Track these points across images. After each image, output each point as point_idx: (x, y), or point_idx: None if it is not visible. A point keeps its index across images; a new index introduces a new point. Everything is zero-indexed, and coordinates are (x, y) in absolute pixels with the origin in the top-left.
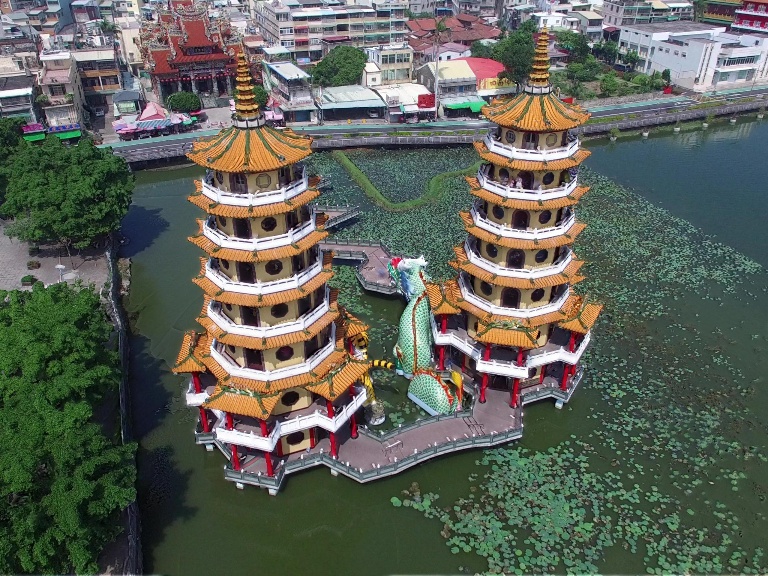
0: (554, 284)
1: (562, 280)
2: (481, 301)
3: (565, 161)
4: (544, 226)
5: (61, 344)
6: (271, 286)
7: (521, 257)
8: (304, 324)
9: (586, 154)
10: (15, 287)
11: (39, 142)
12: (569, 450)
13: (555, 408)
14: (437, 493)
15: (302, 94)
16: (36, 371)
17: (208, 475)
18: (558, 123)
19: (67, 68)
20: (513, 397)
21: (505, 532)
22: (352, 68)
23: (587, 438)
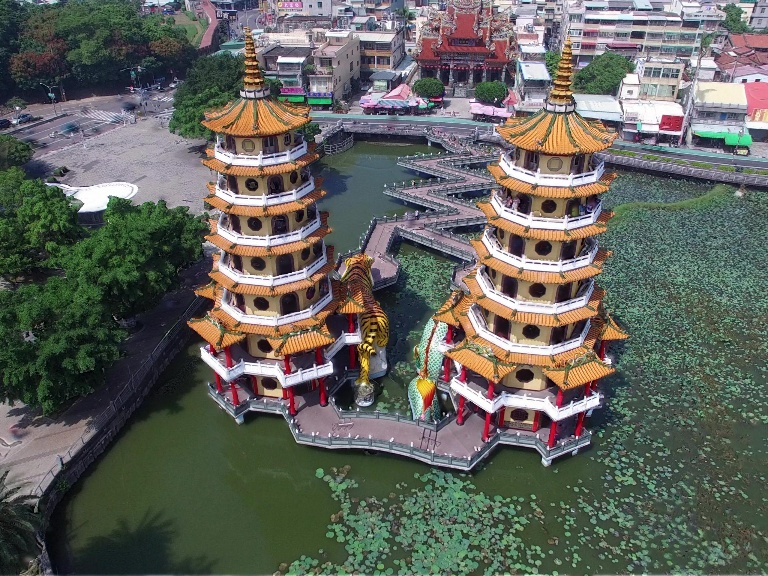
0: (539, 323)
1: (550, 322)
2: (476, 320)
3: (563, 190)
4: (543, 258)
5: (123, 245)
6: (246, 239)
7: (515, 285)
8: (273, 282)
9: (601, 189)
10: (199, 208)
11: (300, 104)
12: (516, 506)
13: (541, 463)
14: (359, 483)
15: (538, 96)
16: (98, 258)
17: None
18: (557, 146)
19: (342, 45)
20: (485, 430)
21: (385, 543)
22: (609, 77)
23: (546, 505)
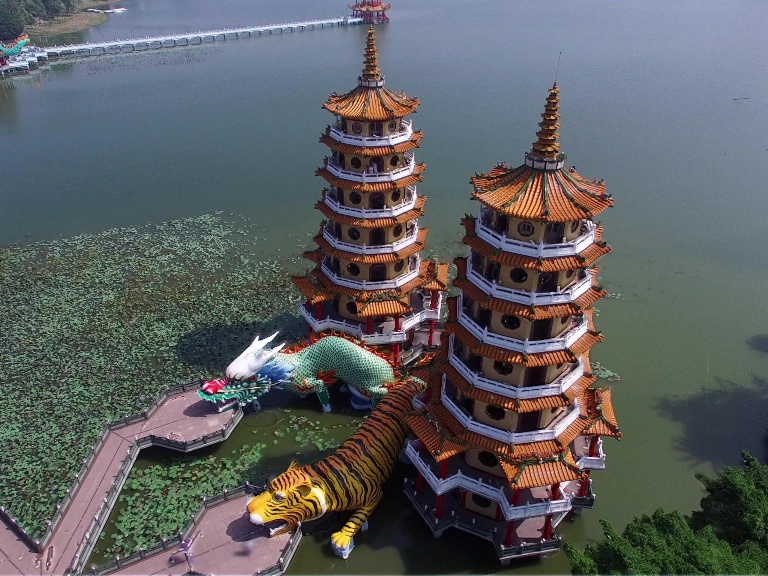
0: None
1: None
2: None
3: None
4: None
5: None
6: None
7: None
8: None
9: None
10: None
11: None
12: None
13: None
14: None
15: None
16: None
17: (557, 571)
18: None
19: None
20: None
21: None
22: None
23: None
